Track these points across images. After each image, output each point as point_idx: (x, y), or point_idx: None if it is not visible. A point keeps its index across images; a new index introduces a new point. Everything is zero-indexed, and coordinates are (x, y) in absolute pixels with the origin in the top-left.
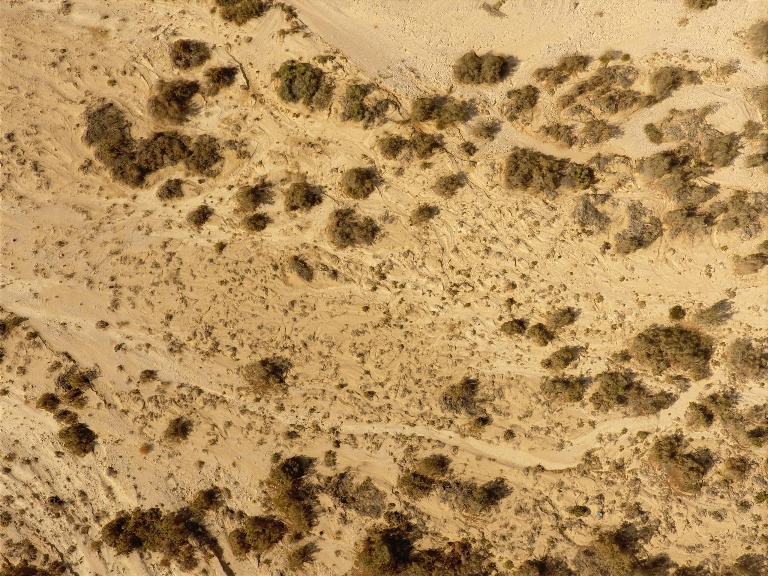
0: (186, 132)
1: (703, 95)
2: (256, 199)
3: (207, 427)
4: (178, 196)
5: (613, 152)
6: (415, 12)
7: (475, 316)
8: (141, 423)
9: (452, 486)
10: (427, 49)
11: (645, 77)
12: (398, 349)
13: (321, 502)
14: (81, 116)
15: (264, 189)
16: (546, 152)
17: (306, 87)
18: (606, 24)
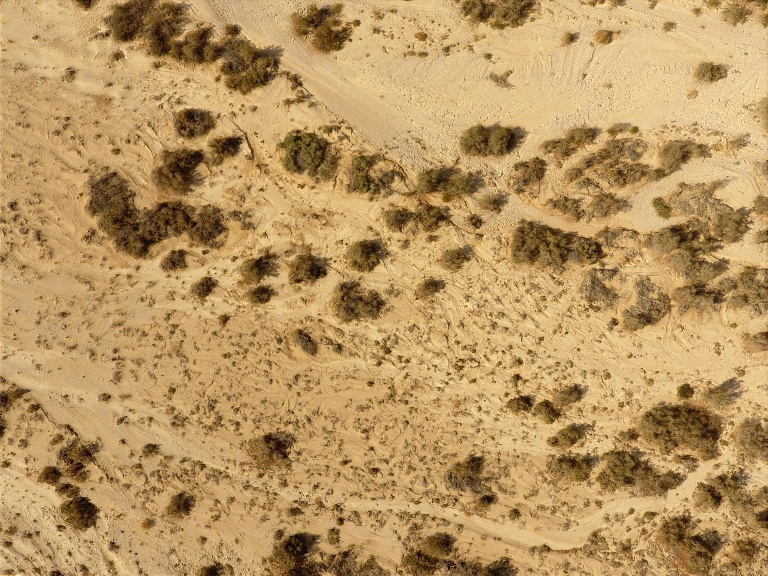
0: (190, 202)
1: (712, 169)
2: (260, 271)
3: (210, 503)
4: (182, 267)
5: (621, 226)
6: (421, 82)
7: (481, 392)
8: (143, 498)
9: (457, 566)
10: (433, 119)
11: (654, 150)
12: (403, 425)
13: None
14: (84, 185)
15: (268, 261)
16: (553, 225)
17: (311, 159)
18: (614, 96)
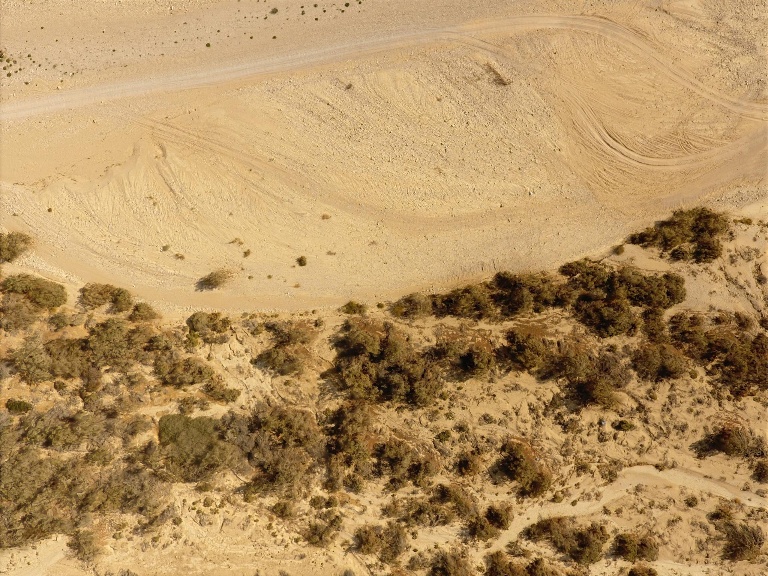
0: None
1: None
2: None
3: None
4: None
5: None
6: None
7: None
8: None
9: None
10: None
11: None
12: None
13: None
14: None
15: None
16: None
17: None
18: None
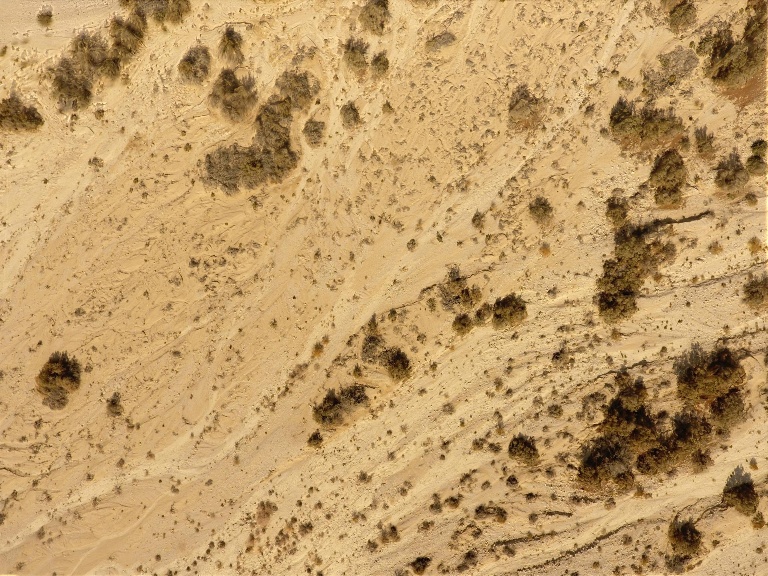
0: (266, 97)
1: None
2: None
3: (549, 185)
4: (322, 127)
5: None
6: None
7: None
8: (519, 245)
9: None
10: None
11: None
12: None
13: (662, 108)
14: (206, 187)
15: (352, 47)
16: None
17: None
18: None
